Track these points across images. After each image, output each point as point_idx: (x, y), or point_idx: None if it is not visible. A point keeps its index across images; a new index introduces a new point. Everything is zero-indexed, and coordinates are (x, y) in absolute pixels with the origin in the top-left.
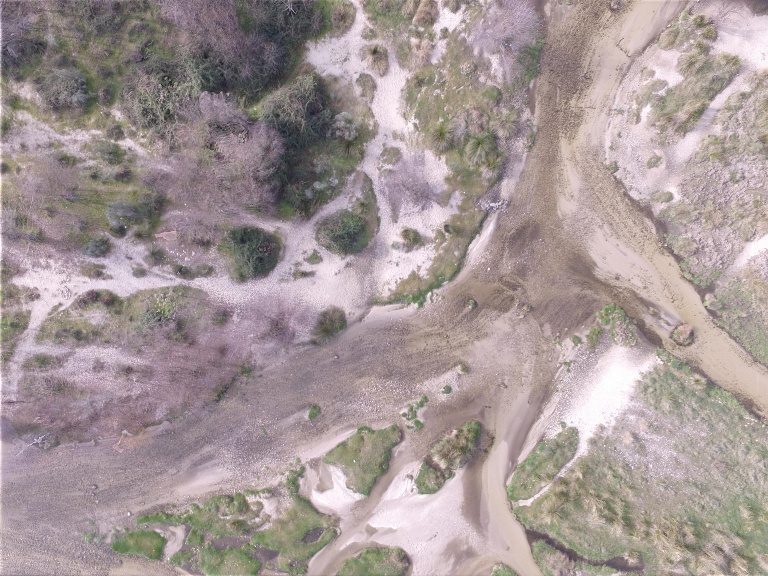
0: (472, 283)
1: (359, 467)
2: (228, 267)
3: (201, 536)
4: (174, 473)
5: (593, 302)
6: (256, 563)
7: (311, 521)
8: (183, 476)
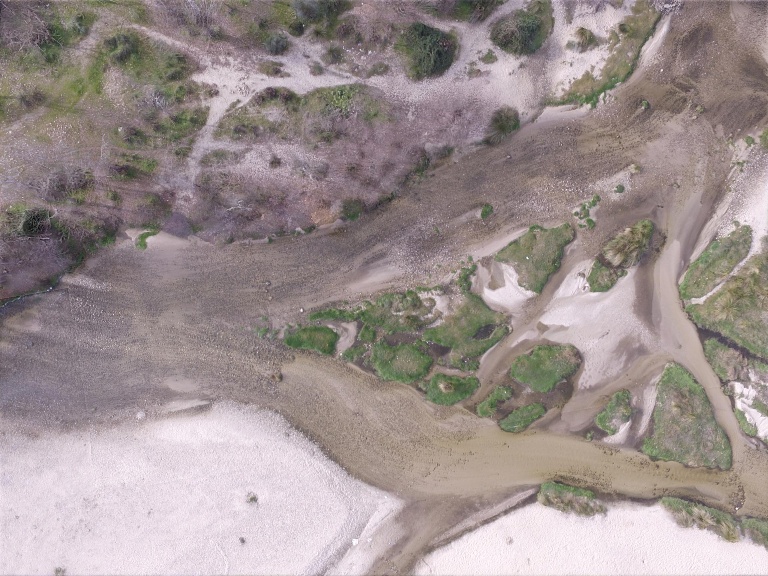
0: (644, 85)
1: (532, 264)
2: (404, 65)
3: (374, 332)
4: (346, 271)
5: (766, 103)
6: (428, 359)
7: (484, 317)
8: (355, 274)
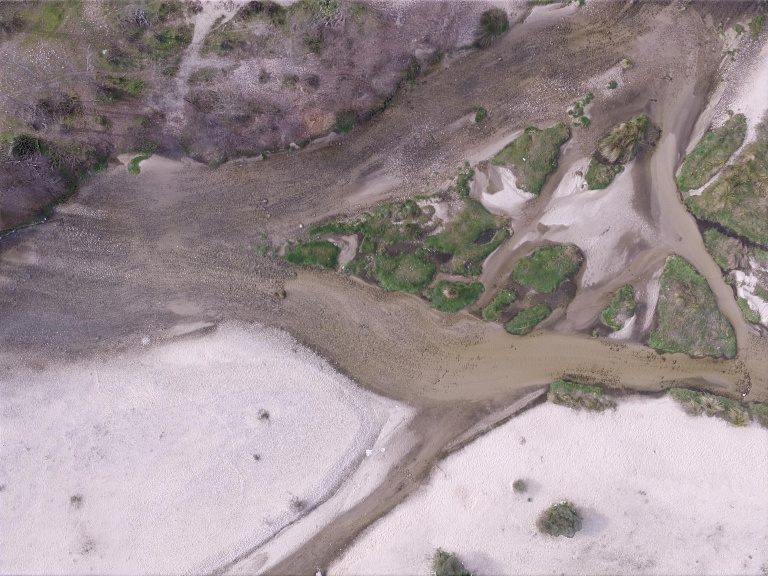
0: None
1: (529, 165)
2: None
3: (375, 243)
4: (343, 184)
5: None
6: (431, 266)
7: (484, 221)
8: (353, 186)
